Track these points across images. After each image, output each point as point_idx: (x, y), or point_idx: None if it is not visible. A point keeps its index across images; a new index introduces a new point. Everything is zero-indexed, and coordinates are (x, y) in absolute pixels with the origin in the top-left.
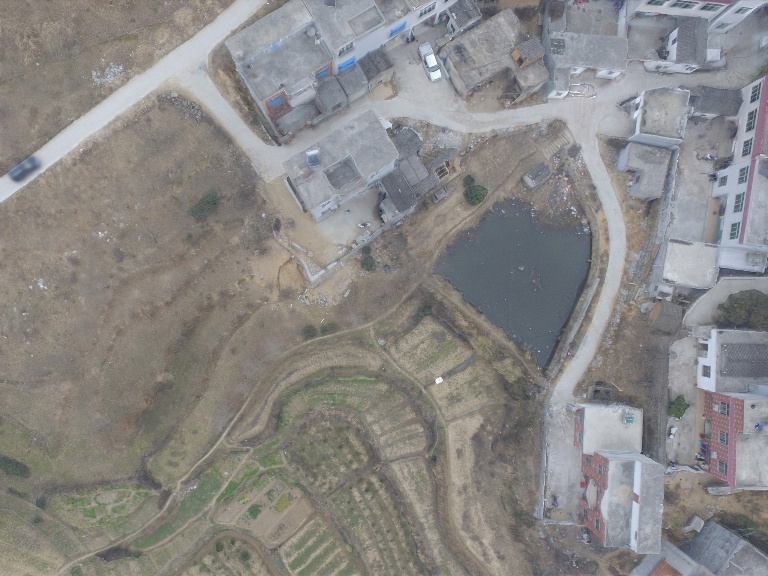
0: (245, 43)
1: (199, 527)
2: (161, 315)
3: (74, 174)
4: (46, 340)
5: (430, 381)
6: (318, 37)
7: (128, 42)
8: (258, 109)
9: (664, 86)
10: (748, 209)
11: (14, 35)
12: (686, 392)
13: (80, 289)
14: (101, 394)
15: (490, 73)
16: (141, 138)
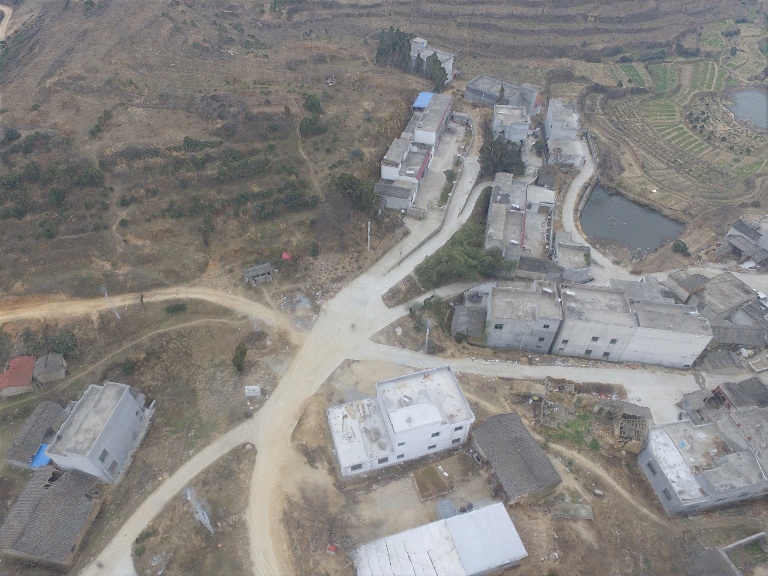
0: None
1: (767, 155)
2: None
3: None
4: None
5: None
6: None
7: None
8: None
9: (578, 269)
10: (526, 195)
11: None
12: (528, 156)
13: None
14: None
15: (716, 278)
16: None
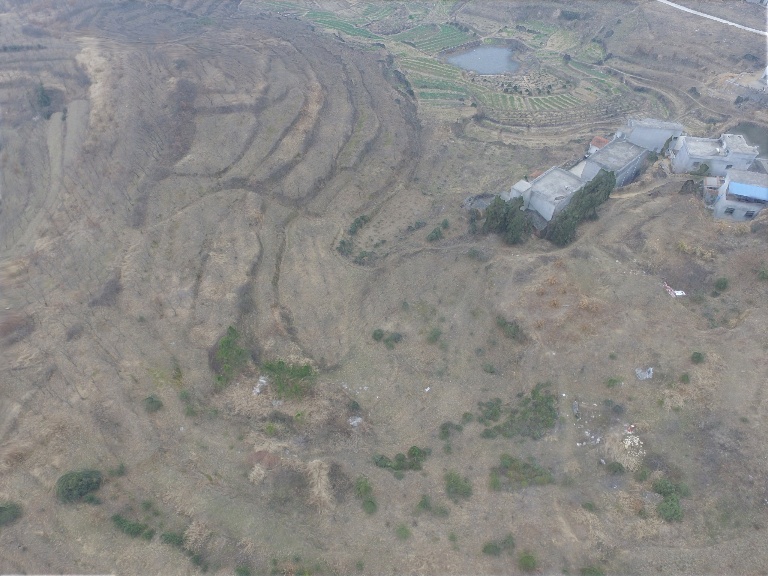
0: None
1: None
2: None
3: None
4: None
5: None
6: None
7: None
8: None
9: None
10: None
11: None
12: None
13: None
14: None
15: None
16: None
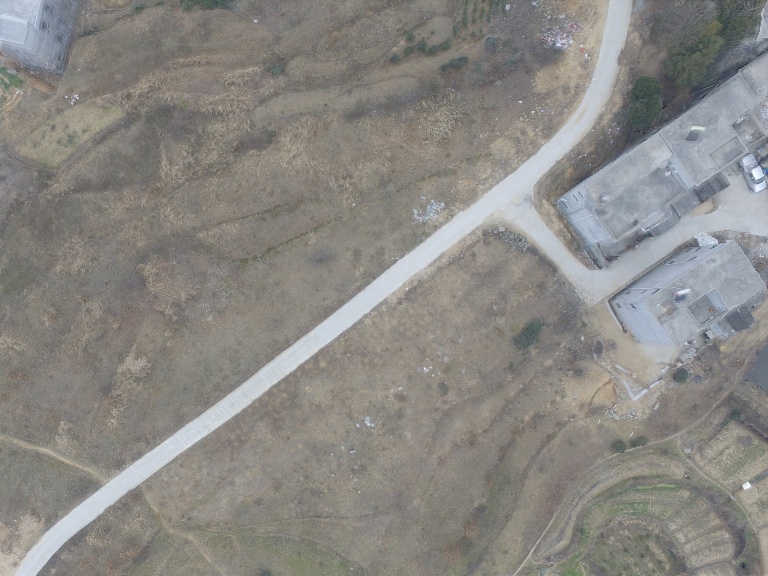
0: (605, 185)
1: None
2: (478, 442)
3: (400, 313)
4: (373, 476)
5: (737, 487)
6: (669, 169)
7: (448, 178)
8: (575, 233)
9: None
10: None
11: (328, 177)
12: None
13: (406, 424)
14: (420, 523)
15: None
16: (466, 273)
